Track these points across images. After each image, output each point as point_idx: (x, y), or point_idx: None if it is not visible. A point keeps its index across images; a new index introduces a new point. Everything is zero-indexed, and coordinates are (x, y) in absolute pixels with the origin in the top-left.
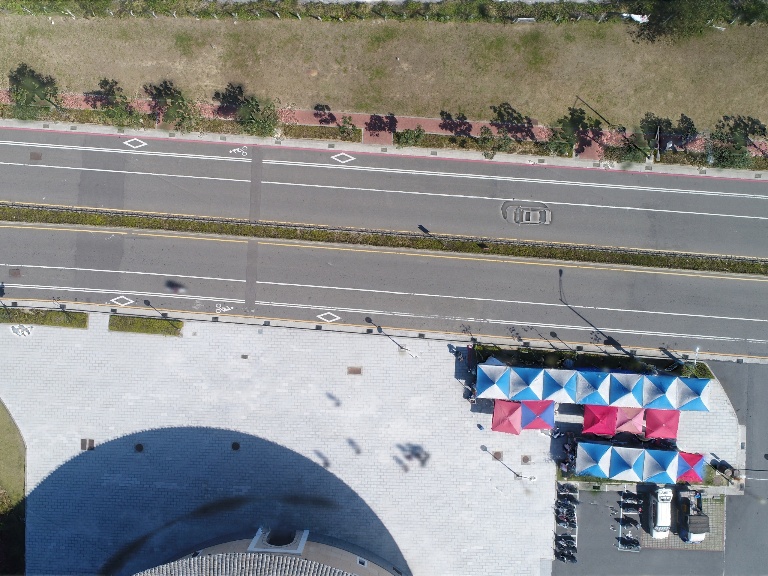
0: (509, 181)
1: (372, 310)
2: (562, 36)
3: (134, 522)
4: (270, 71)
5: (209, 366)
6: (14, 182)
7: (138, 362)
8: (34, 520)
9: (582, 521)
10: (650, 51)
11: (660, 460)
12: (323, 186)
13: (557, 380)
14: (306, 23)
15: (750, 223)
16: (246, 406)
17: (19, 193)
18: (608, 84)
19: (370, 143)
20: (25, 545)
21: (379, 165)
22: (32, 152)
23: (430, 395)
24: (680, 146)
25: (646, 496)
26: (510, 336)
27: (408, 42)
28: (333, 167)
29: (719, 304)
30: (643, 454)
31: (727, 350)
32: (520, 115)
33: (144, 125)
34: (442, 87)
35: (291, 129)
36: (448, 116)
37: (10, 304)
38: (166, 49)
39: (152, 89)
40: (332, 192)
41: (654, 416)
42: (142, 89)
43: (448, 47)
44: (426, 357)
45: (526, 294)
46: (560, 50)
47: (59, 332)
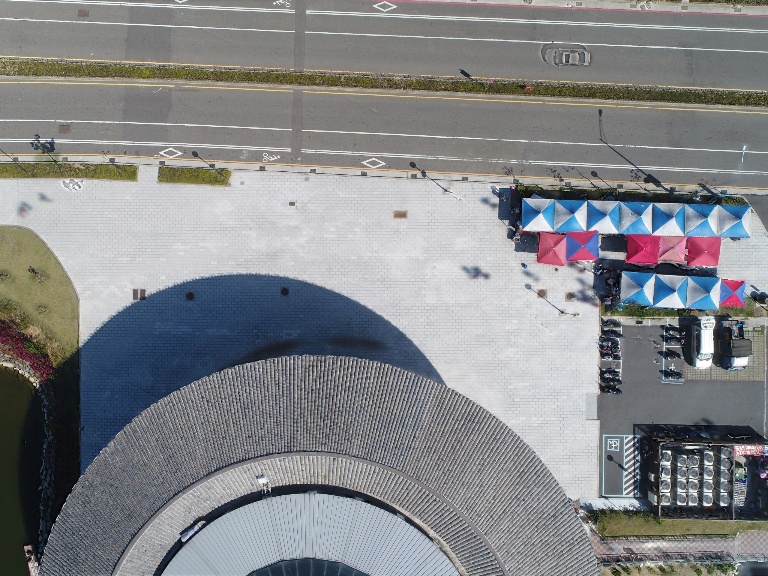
0: (548, 24)
1: (416, 155)
2: None
3: (187, 369)
4: None
5: (257, 214)
6: (62, 39)
7: (187, 212)
8: (88, 370)
9: (626, 355)
10: None
11: (703, 285)
12: (366, 34)
13: (601, 209)
14: None
15: None
16: (294, 252)
17: (67, 50)
18: None
19: None
20: (80, 395)
21: (420, 12)
22: (79, 9)
23: (475, 236)
24: None
25: (688, 329)
26: (552, 176)
27: None
28: (375, 16)
29: (756, 139)
30: (686, 281)
31: (765, 184)
32: None
33: None
34: None
35: None
36: None
37: (60, 159)
38: None
39: None
40: (375, 40)
41: (696, 243)
42: None
43: None
44: (470, 199)
45: (567, 134)
46: None
47: (109, 185)
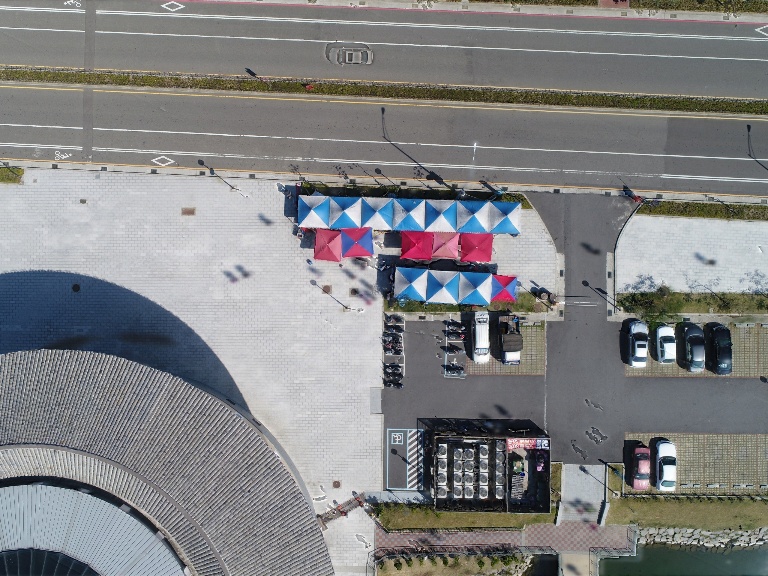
0: (332, 24)
1: (204, 153)
2: None
3: None
4: None
5: (49, 211)
6: None
7: None
8: None
9: (409, 350)
10: None
11: (473, 280)
12: (154, 34)
13: (373, 206)
14: None
15: (563, 57)
16: (85, 249)
17: None
18: None
19: None
20: None
21: (207, 12)
22: None
23: (261, 233)
24: None
25: (469, 324)
26: (337, 174)
27: None
28: (163, 15)
29: (535, 137)
30: (458, 276)
31: (544, 181)
32: None
33: None
34: None
35: None
36: None
37: None
38: None
39: None
40: (163, 39)
41: (468, 239)
42: None
43: None
44: (256, 196)
45: (351, 132)
46: None
47: None
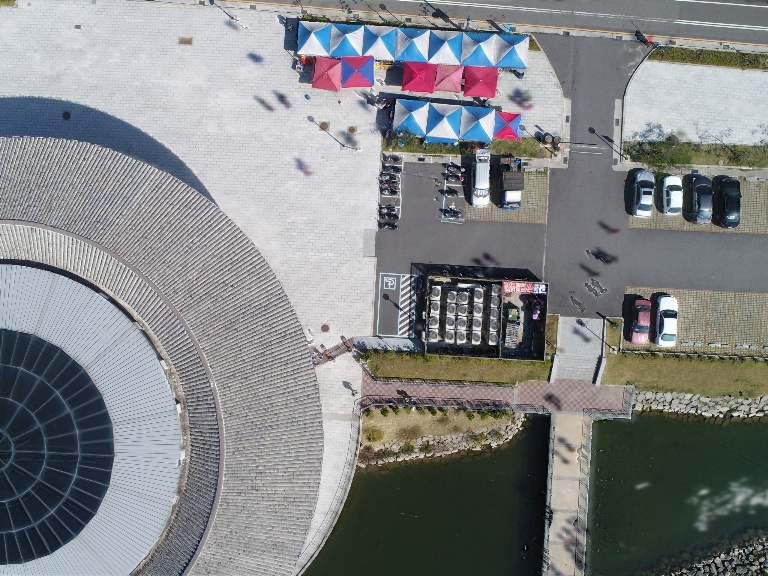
0: None
1: None
2: None
3: None
4: None
5: (42, 36)
6: None
7: None
8: None
9: (406, 192)
10: None
11: (475, 114)
12: None
13: (375, 33)
14: None
15: None
16: (78, 76)
17: None
18: None
19: None
20: None
21: None
22: None
23: (259, 65)
24: None
25: (470, 167)
26: (340, 8)
27: None
28: None
29: None
30: (460, 110)
31: (554, 23)
32: None
33: None
34: None
35: None
36: None
37: None
38: None
39: None
40: None
41: (472, 72)
42: None
43: None
44: (256, 28)
45: None
46: None
47: None
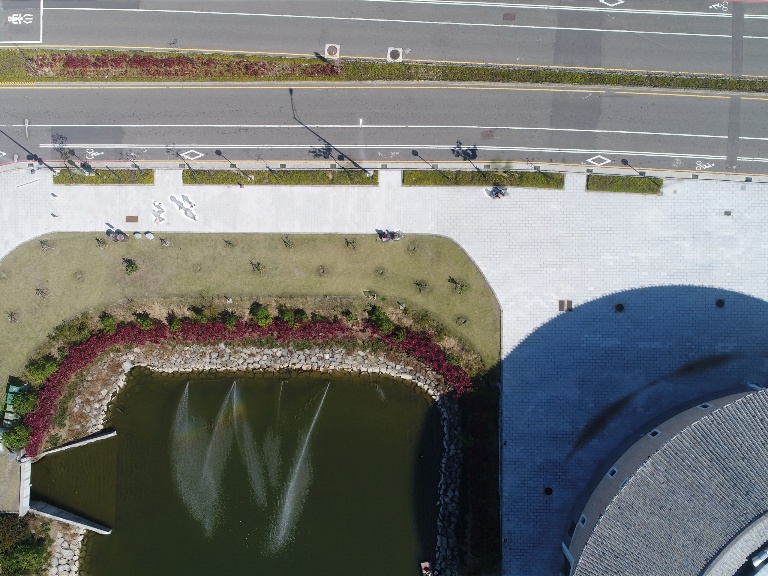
0: None
1: None
2: None
3: (616, 382)
4: None
5: (691, 224)
6: (487, 43)
7: (617, 221)
8: (511, 383)
9: None
10: None
11: None
12: None
13: None
14: None
15: None
16: (730, 263)
17: (492, 54)
18: None
19: None
20: (502, 409)
21: None
22: (505, 12)
23: None
24: None
25: None
26: None
27: None
28: None
29: None
30: None
31: None
32: None
33: None
34: None
35: None
36: None
37: (482, 167)
38: None
39: None
40: None
41: None
42: None
43: None
44: None
45: None
46: None
47: (534, 193)
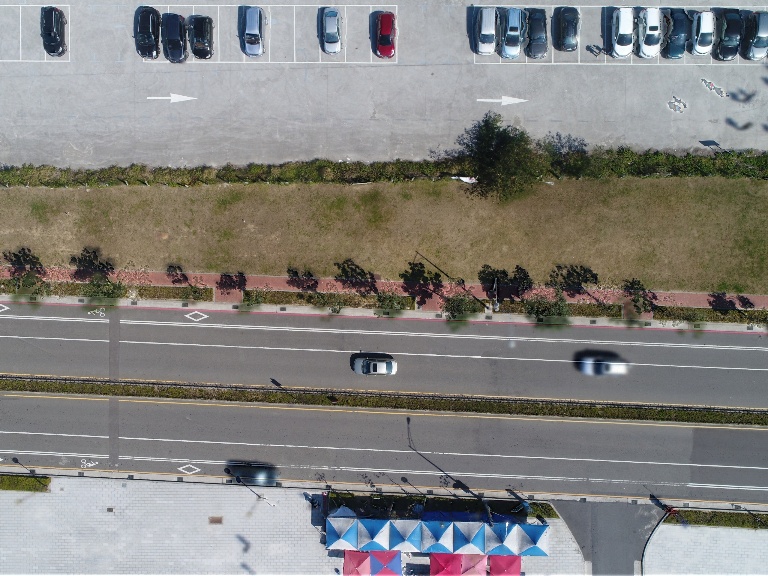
0: (356, 334)
1: (230, 461)
2: (399, 194)
3: None
4: (123, 236)
5: (77, 520)
6: None
7: (9, 518)
8: None
9: None
10: (484, 207)
11: None
12: (178, 344)
13: (401, 532)
14: (155, 189)
15: (587, 368)
16: (113, 557)
17: None
18: (445, 239)
19: (221, 301)
20: None
21: (231, 322)
22: None
23: (288, 542)
24: (517, 296)
25: None
26: (363, 482)
27: (253, 204)
28: (187, 325)
29: (561, 446)
30: None
31: (570, 490)
32: (363, 271)
33: (5, 290)
34: (287, 246)
35: (145, 290)
36: (295, 274)
37: None
38: (23, 217)
39: (11, 256)
40: (187, 349)
41: (496, 562)
42: (2, 256)
43: (291, 208)
44: (283, 505)
45: (376, 442)
46: (398, 208)
47: None
